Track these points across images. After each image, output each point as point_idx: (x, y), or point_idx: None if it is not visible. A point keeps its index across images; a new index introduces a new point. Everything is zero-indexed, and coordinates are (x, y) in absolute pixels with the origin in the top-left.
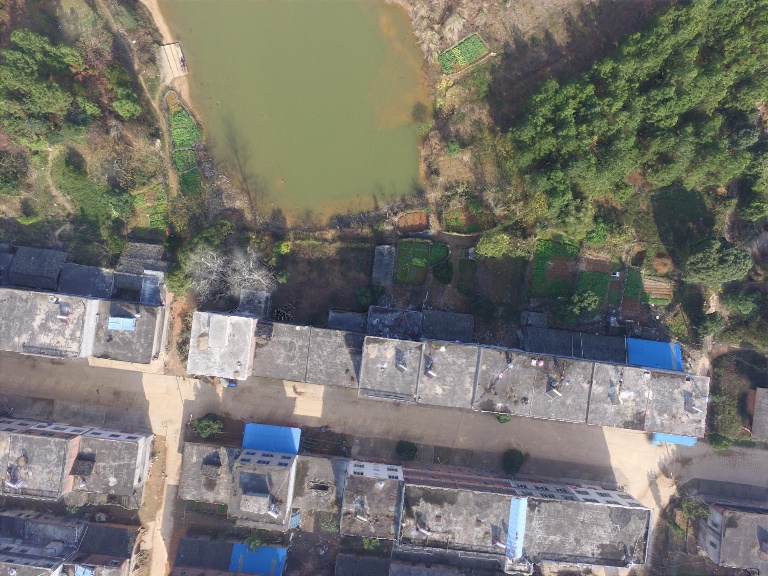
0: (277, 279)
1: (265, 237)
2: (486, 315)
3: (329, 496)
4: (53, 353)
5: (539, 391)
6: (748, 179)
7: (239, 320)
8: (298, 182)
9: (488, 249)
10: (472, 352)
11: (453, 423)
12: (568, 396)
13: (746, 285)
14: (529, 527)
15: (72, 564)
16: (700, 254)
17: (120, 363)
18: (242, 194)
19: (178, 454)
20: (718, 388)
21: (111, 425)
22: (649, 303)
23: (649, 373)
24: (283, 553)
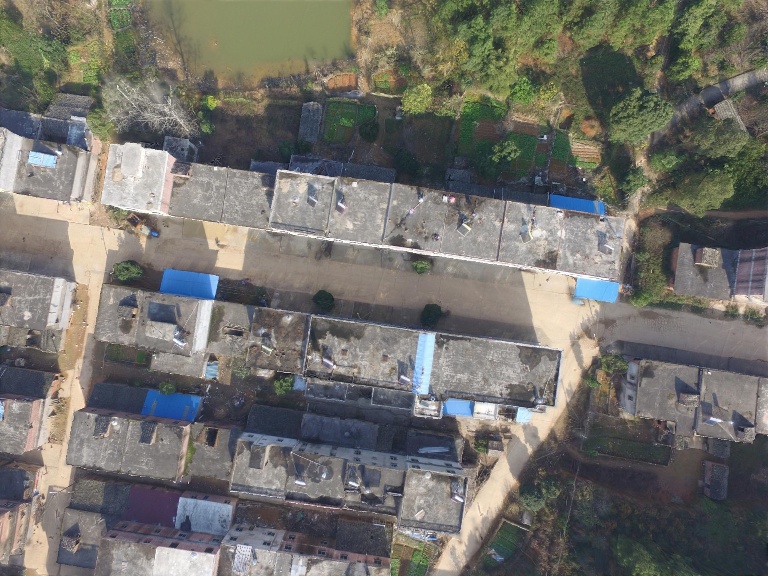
0: (200, 127)
1: (195, 95)
2: (410, 172)
3: (244, 342)
4: None
5: (450, 228)
6: (675, 38)
7: (154, 153)
8: (231, 45)
9: (411, 101)
10: (384, 188)
11: (374, 279)
12: (479, 234)
13: (675, 148)
14: (436, 364)
15: None
16: (621, 103)
17: (47, 212)
18: (175, 55)
19: None
20: (643, 248)
21: (34, 271)
22: (576, 166)
23: (562, 212)
24: (197, 400)
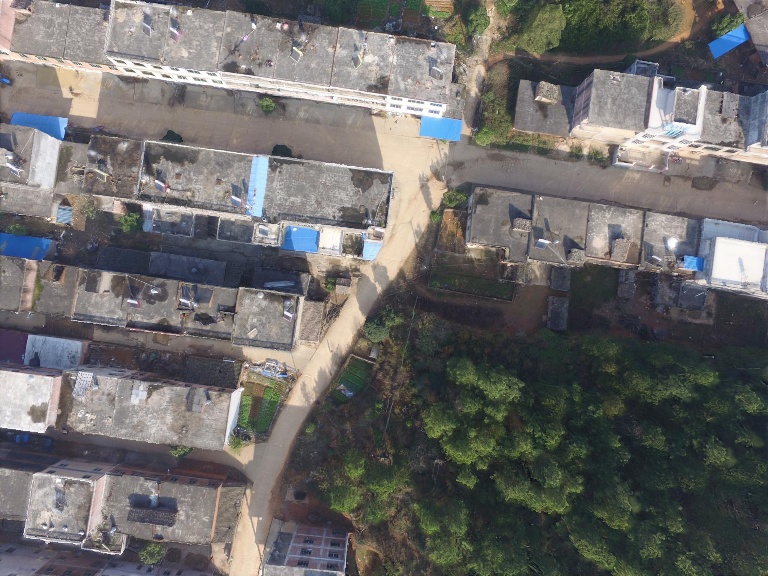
0: None
1: None
2: None
3: None
4: None
5: (283, 54)
6: None
7: None
8: None
9: None
10: (219, 17)
11: (227, 125)
12: (312, 60)
13: None
14: (270, 188)
15: None
16: None
17: None
18: None
19: None
20: (489, 90)
21: None
22: (429, 16)
23: (394, 38)
24: (48, 242)
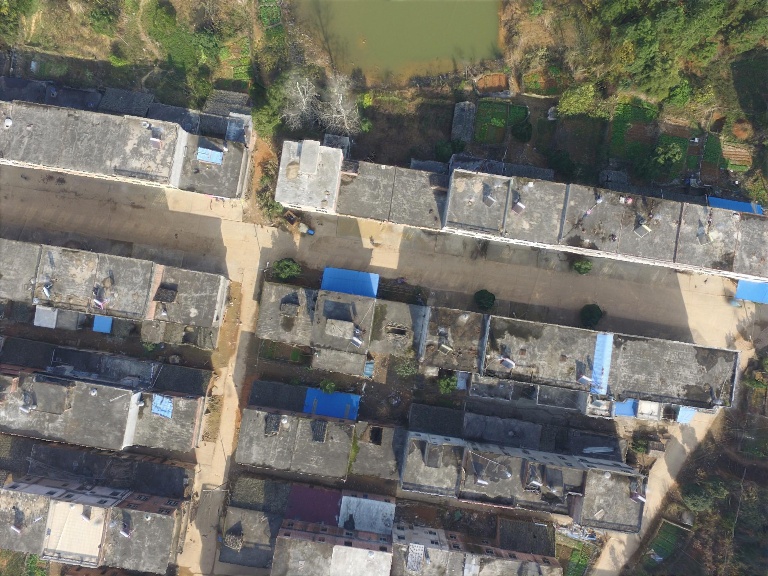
0: (361, 125)
1: (346, 93)
2: (565, 173)
3: (406, 341)
4: (143, 177)
5: (627, 229)
6: None
7: (328, 150)
8: (379, 43)
9: (571, 102)
10: (560, 189)
11: (529, 279)
12: (656, 235)
13: None
14: (614, 365)
15: (150, 393)
16: None
17: (199, 209)
18: (323, 53)
19: (253, 301)
20: None
21: (189, 268)
22: (728, 169)
23: (738, 214)
24: (357, 399)
